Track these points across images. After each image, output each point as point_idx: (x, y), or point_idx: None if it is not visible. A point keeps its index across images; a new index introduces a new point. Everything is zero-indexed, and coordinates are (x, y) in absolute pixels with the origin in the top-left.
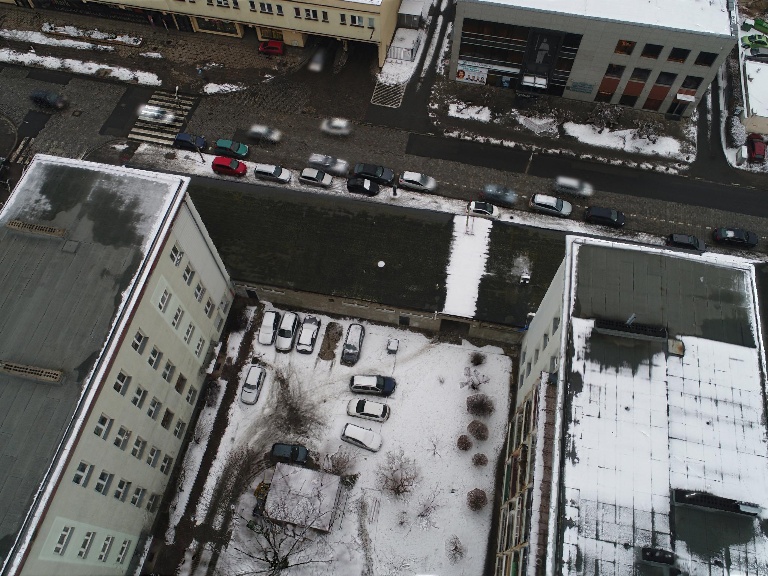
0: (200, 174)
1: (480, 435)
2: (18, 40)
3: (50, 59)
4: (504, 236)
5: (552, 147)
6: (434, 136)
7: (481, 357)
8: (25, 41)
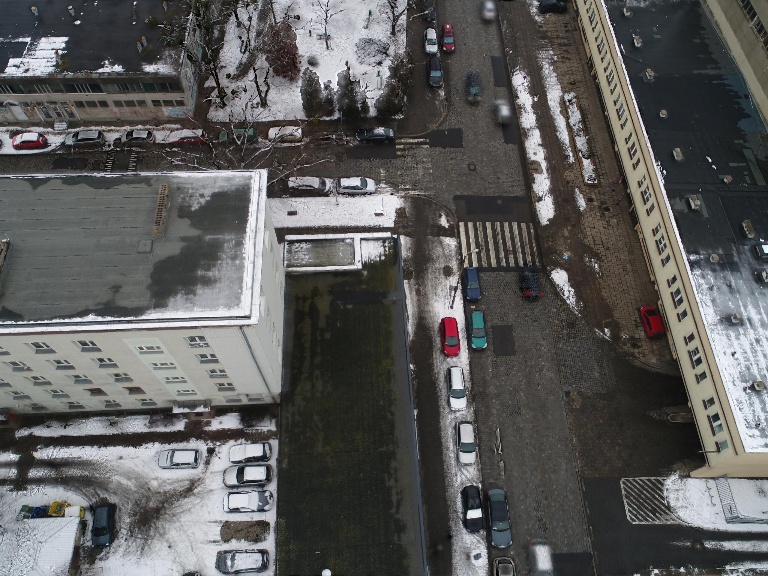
0: (433, 309)
1: None
2: (544, 82)
3: (532, 117)
4: None
5: None
6: None
7: None
8: (545, 88)
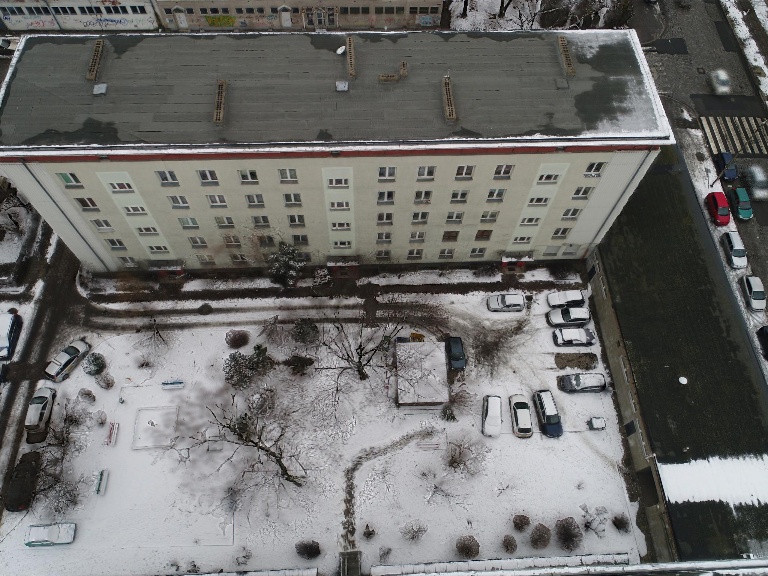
0: (696, 188)
1: (536, 540)
2: None
3: (745, 28)
4: None
5: None
6: None
7: (626, 528)
8: (752, 4)
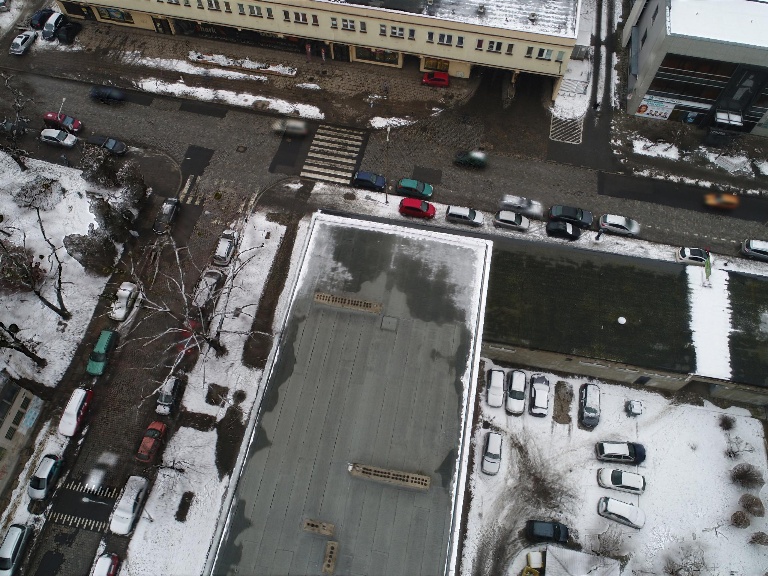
0: (386, 216)
1: (753, 510)
2: (164, 69)
3: (201, 90)
4: (744, 289)
5: (750, 187)
6: (624, 175)
7: (730, 420)
8: (171, 70)
